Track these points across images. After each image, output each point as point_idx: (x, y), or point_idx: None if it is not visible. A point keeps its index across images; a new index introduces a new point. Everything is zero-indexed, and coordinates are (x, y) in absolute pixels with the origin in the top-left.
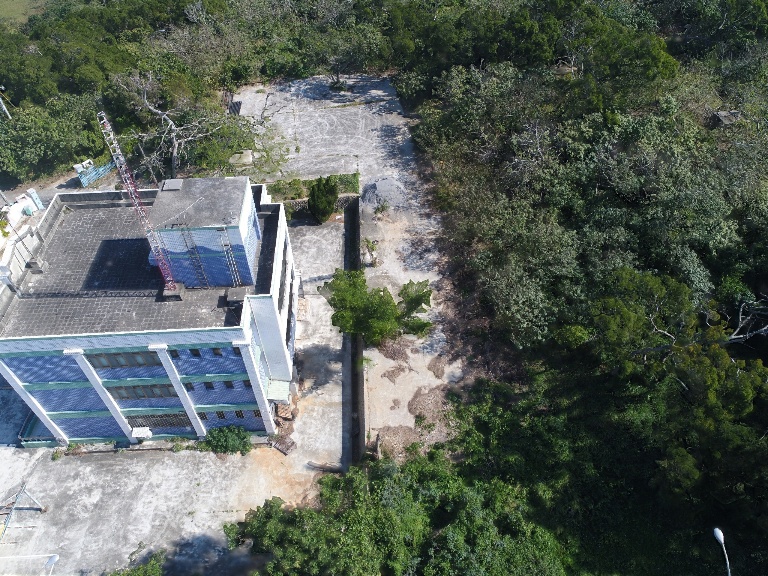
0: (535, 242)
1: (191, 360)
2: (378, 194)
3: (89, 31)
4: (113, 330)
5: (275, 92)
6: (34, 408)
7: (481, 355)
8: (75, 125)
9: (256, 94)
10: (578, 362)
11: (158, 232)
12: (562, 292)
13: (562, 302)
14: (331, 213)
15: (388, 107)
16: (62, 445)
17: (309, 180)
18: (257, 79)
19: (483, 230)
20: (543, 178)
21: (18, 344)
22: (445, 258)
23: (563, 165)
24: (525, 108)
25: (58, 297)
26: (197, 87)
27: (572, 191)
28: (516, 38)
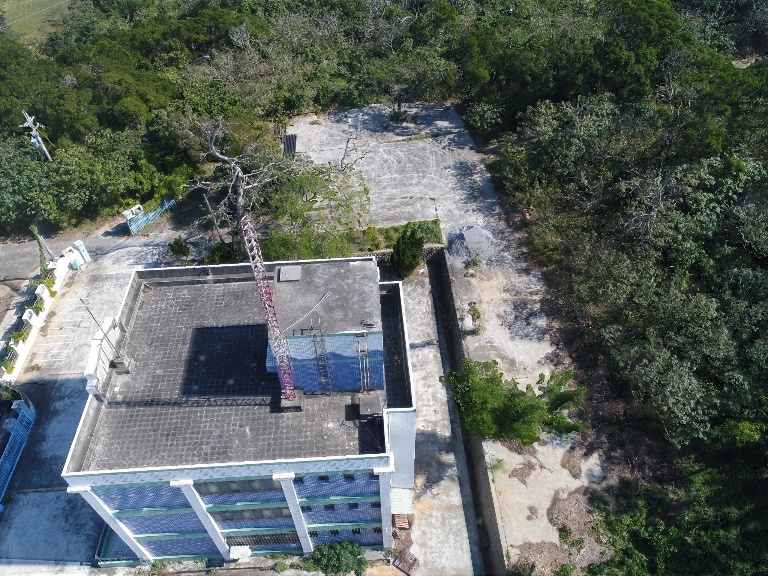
0: (674, 315)
1: (316, 484)
2: (467, 246)
3: (125, 56)
4: (226, 453)
5: (331, 123)
6: (121, 533)
7: (620, 448)
8: (122, 166)
9: (311, 126)
10: (738, 459)
11: (284, 339)
12: (711, 374)
13: (713, 387)
14: (415, 267)
15: (458, 141)
16: (145, 564)
17: (385, 228)
18: (310, 109)
19: (609, 298)
20: (665, 234)
21: (117, 477)
22: (555, 324)
23: (683, 217)
24: (626, 148)
25: (153, 406)
26: (249, 120)
27: (698, 249)
28: (603, 67)
